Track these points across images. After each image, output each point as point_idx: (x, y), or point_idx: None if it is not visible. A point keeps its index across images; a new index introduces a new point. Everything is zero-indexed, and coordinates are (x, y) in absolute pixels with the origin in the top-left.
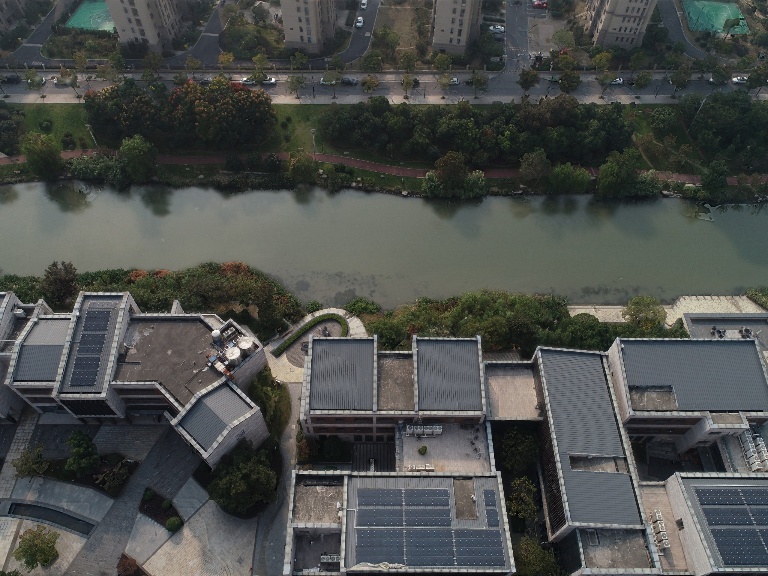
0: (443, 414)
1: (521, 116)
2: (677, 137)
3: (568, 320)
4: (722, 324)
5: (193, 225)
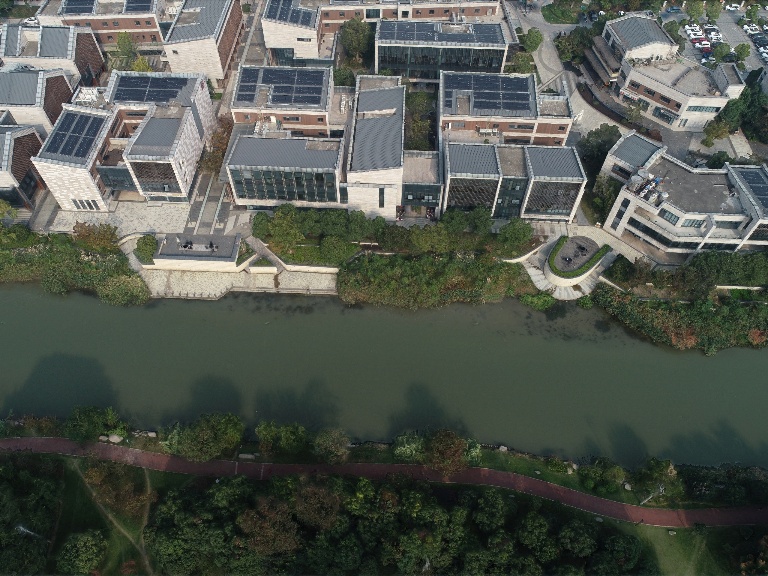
0: (476, 143)
1: (339, 503)
2: (75, 531)
3: (358, 225)
4: (202, 256)
5: (762, 413)
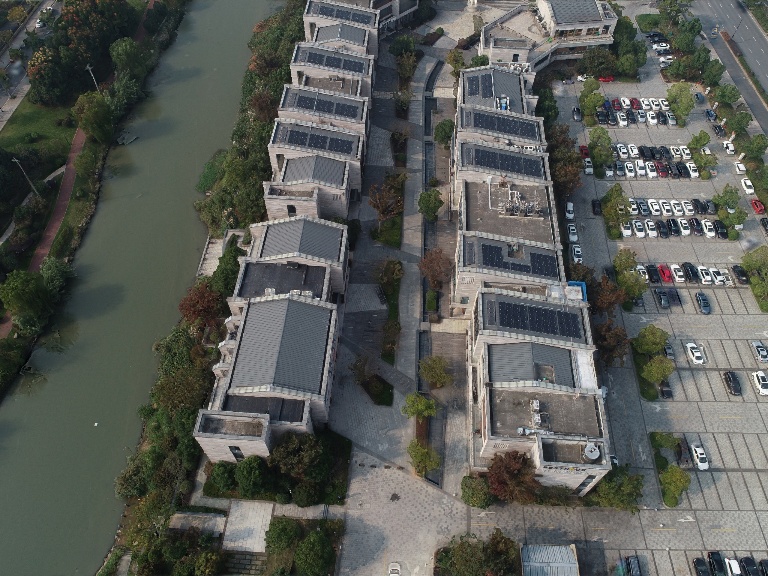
0: None
1: None
2: None
3: None
4: None
5: (204, 57)
